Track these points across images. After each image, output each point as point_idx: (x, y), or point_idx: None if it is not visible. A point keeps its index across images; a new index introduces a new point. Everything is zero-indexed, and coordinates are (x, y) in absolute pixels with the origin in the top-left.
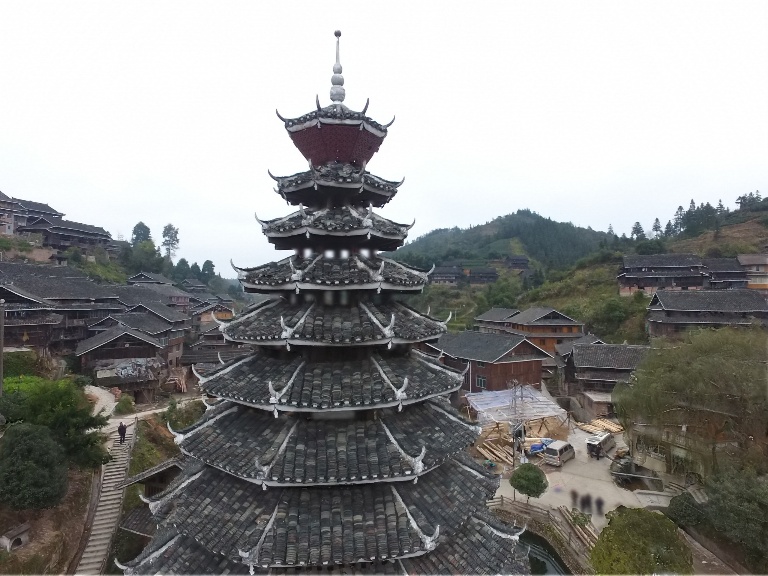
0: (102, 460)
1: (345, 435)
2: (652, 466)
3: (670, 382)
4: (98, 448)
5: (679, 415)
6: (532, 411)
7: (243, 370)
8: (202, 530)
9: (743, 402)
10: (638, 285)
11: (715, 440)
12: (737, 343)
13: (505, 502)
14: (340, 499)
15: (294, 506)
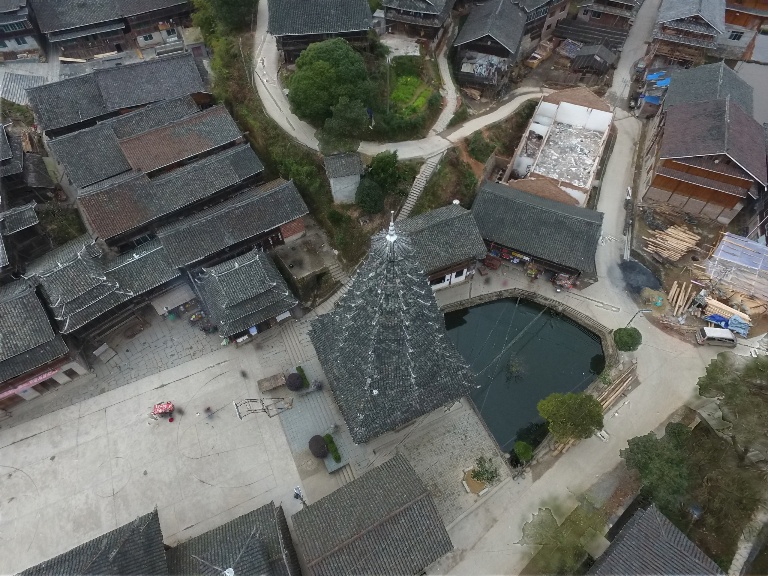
0: (404, 193)
1: None
2: None
3: None
4: (415, 171)
5: None
6: None
7: None
8: None
9: None
10: None
11: None
12: None
13: (611, 334)
14: None
15: None
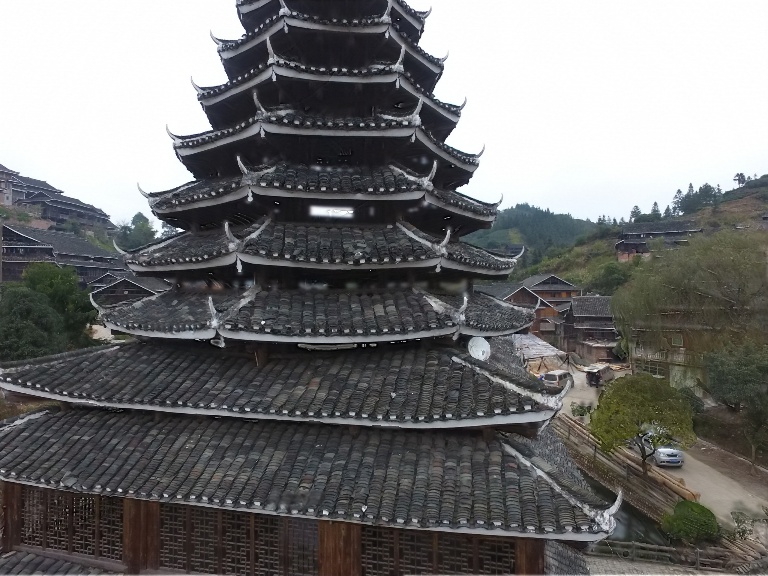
0: None
1: (343, 120)
2: None
3: (668, 276)
4: None
5: (677, 319)
6: (531, 351)
7: None
8: None
9: (741, 294)
10: None
11: None
12: (735, 238)
13: None
14: (338, 170)
15: (292, 168)
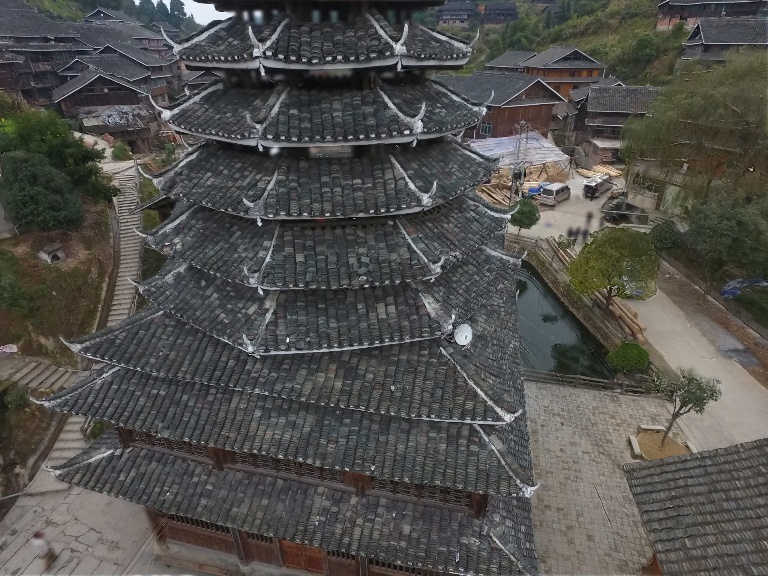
0: (111, 193)
1: (340, 103)
2: (642, 204)
3: (688, 110)
4: None
5: (686, 148)
6: (535, 157)
7: (220, 35)
8: (207, 196)
9: (758, 130)
10: (681, 15)
11: (713, 177)
12: None
13: None
14: (339, 167)
15: (293, 171)
